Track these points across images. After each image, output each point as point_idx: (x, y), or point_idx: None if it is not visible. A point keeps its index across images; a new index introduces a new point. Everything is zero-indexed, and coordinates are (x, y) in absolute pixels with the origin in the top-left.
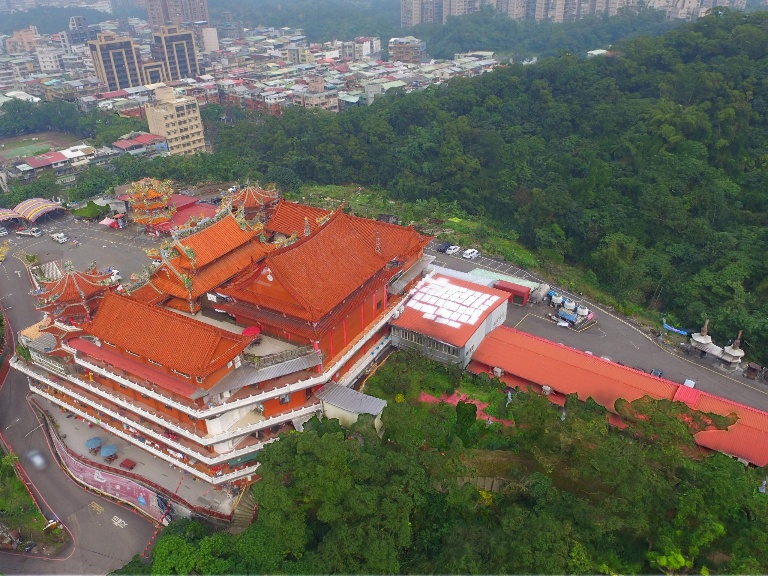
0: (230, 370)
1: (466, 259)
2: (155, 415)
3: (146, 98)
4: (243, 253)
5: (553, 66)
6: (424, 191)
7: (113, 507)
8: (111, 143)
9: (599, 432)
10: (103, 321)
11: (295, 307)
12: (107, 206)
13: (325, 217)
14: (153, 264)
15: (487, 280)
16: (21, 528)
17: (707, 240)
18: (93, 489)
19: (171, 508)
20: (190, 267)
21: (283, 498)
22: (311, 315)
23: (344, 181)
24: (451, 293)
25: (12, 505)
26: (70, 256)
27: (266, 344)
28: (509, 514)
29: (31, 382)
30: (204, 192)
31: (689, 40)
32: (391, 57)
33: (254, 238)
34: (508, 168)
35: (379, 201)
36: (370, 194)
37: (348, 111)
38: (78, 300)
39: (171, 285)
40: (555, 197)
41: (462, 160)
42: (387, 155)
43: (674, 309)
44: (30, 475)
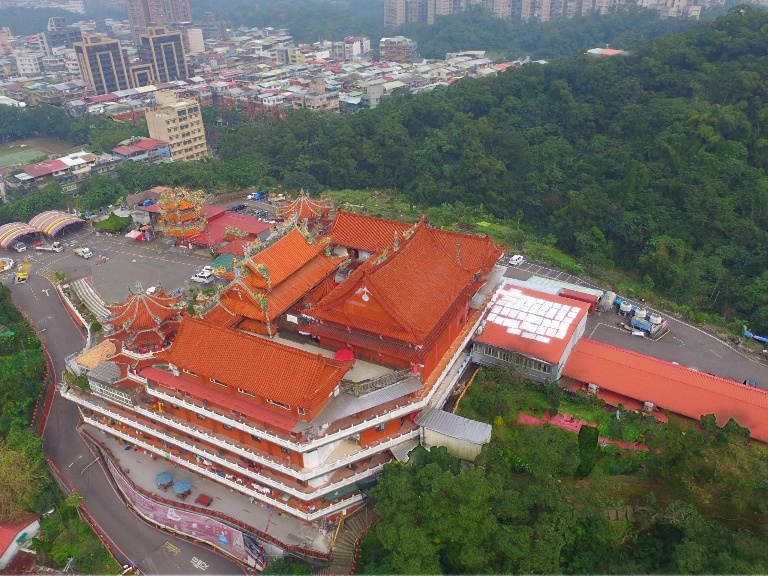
0: (329, 399)
1: (513, 266)
2: (243, 449)
3: (138, 102)
4: (311, 268)
5: (570, 66)
6: (447, 195)
7: (190, 547)
8: (111, 149)
9: (767, 460)
10: (183, 349)
11: (394, 328)
12: (130, 217)
13: (410, 230)
14: (192, 279)
15: (554, 289)
16: (92, 575)
17: (758, 241)
18: (165, 528)
19: (263, 548)
20: (265, 286)
21: (422, 542)
22: (414, 337)
23: (359, 185)
24: (529, 305)
25: (79, 550)
26: (99, 272)
27: (359, 368)
28: (681, 553)
29: (84, 413)
30: (222, 200)
31: (714, 39)
32: (382, 57)
33: (319, 252)
34: (536, 170)
35: (398, 205)
36: (387, 198)
37: (359, 113)
38: (151, 326)
39: (243, 306)
40: (595, 200)
41: (487, 162)
42: (405, 158)
43: (734, 313)
44: (94, 515)
